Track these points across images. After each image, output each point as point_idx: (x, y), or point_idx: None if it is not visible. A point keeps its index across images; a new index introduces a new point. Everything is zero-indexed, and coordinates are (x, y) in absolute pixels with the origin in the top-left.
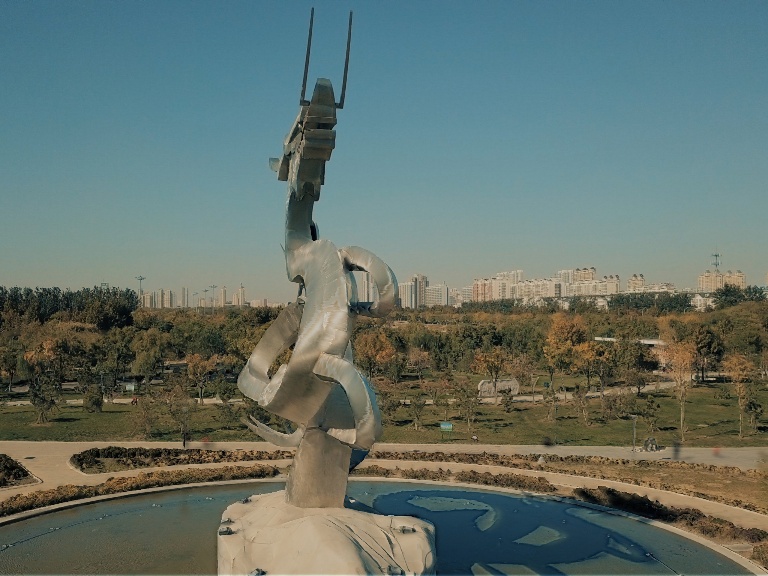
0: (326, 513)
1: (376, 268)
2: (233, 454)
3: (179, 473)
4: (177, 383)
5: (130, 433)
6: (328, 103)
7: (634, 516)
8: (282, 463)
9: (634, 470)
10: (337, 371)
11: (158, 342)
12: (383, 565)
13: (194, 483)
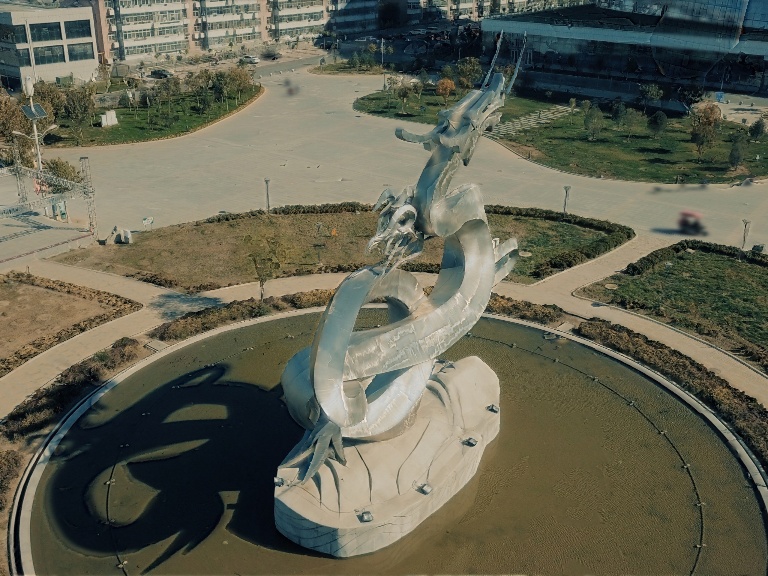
0: None
1: None
2: None
3: None
4: None
5: None
6: None
7: (107, 389)
8: None
9: None
10: None
11: None
12: None
13: None
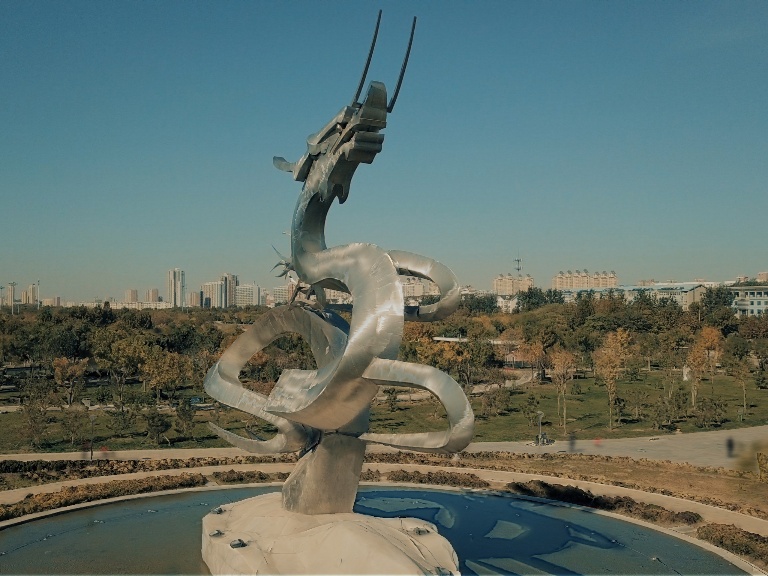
0: (341, 519)
1: (439, 273)
2: (145, 463)
3: (105, 486)
4: (36, 389)
5: (14, 445)
6: (380, 106)
7: (577, 506)
8: (203, 470)
9: (543, 463)
10: (417, 376)
11: (0, 345)
12: (426, 567)
13: (125, 496)
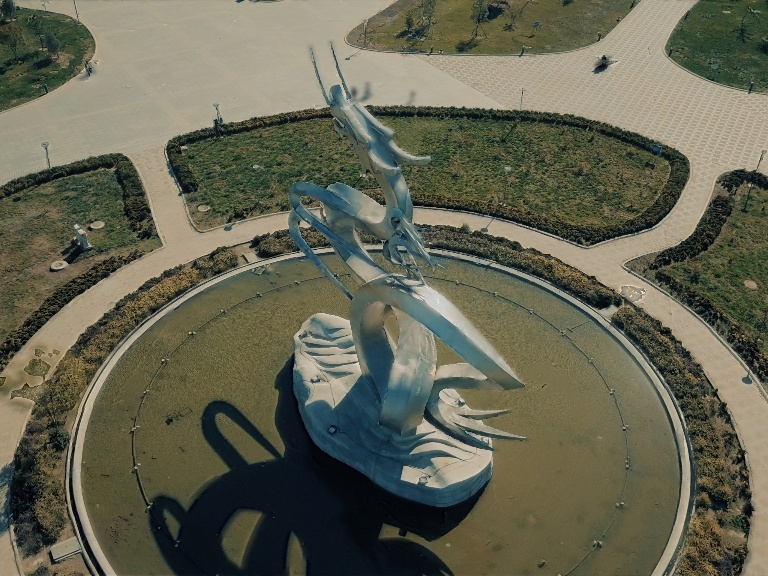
0: None
1: None
2: None
3: None
4: None
5: None
6: None
7: None
8: None
9: None
10: None
11: None
12: None
13: None
